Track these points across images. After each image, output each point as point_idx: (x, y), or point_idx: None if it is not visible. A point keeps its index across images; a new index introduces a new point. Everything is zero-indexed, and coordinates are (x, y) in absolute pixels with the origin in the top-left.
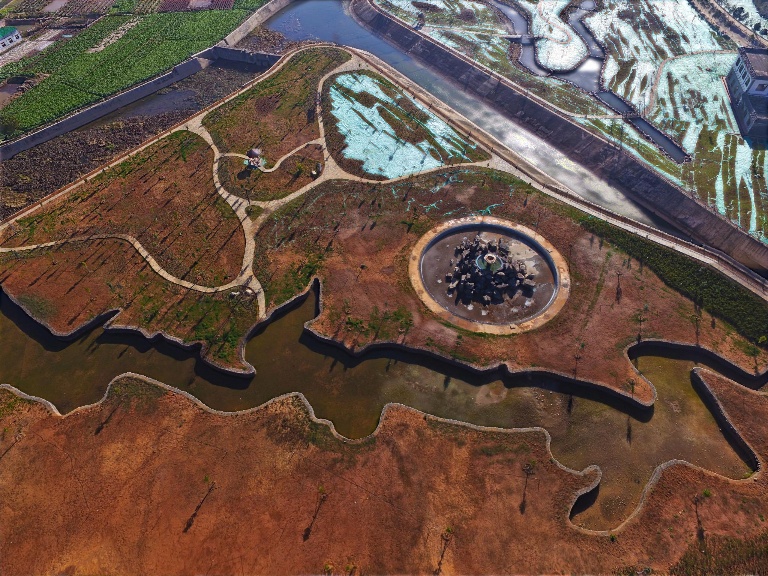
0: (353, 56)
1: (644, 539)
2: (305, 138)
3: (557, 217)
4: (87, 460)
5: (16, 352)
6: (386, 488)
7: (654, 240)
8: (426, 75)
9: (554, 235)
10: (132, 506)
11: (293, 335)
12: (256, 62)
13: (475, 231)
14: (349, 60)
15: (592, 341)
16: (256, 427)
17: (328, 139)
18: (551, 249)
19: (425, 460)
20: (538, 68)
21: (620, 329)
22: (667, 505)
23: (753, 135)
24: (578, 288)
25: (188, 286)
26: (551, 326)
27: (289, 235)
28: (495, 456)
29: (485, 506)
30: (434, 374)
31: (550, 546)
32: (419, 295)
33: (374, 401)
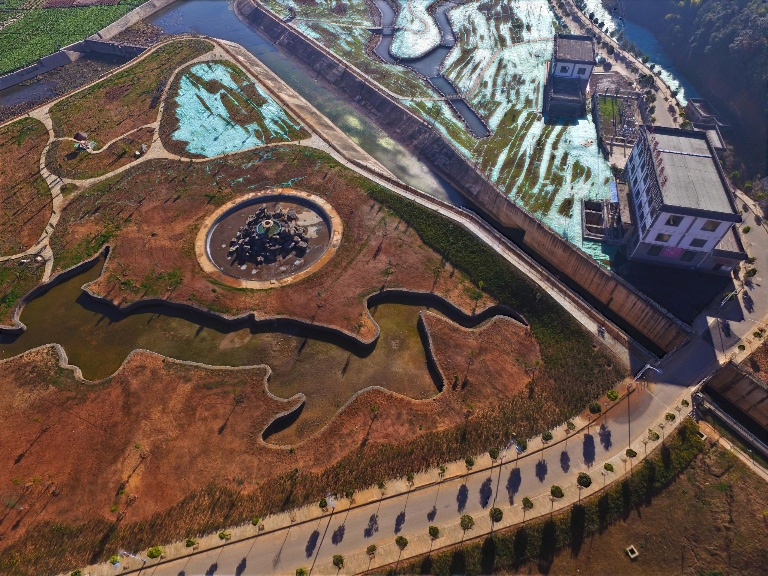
0: (216, 47)
1: (318, 450)
2: (141, 122)
3: (349, 187)
4: None
5: None
6: (106, 419)
7: (424, 204)
8: (286, 64)
9: (341, 203)
10: None
11: (72, 296)
12: (125, 54)
13: (273, 202)
14: (210, 51)
15: (338, 292)
16: (5, 374)
17: (162, 123)
18: (334, 215)
19: (150, 395)
20: (389, 56)
21: (368, 281)
22: (349, 422)
23: (552, 112)
24: (344, 248)
25: None
26: (308, 280)
27: (94, 209)
28: (214, 389)
29: (188, 429)
30: (190, 325)
31: (233, 458)
32: (198, 258)
33: (127, 349)
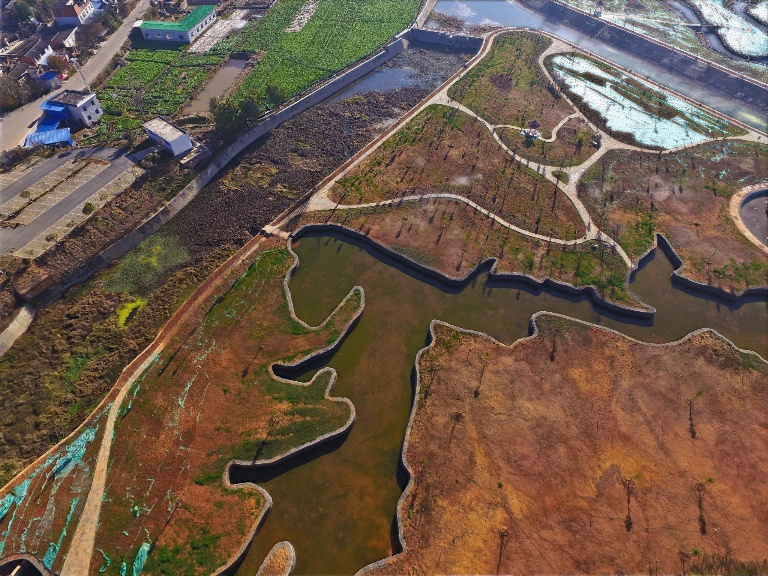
0: (553, 40)
1: None
2: (563, 112)
3: None
4: (562, 381)
5: (419, 294)
6: None
7: None
8: (624, 59)
9: None
10: (631, 418)
11: (664, 282)
12: (455, 44)
13: None
14: (552, 43)
15: None
16: (693, 356)
17: (585, 114)
18: None
19: None
20: (732, 54)
21: None
22: None
23: None
24: None
25: (546, 239)
26: None
27: (609, 197)
28: None
29: None
30: None
31: None
32: (762, 249)
33: None
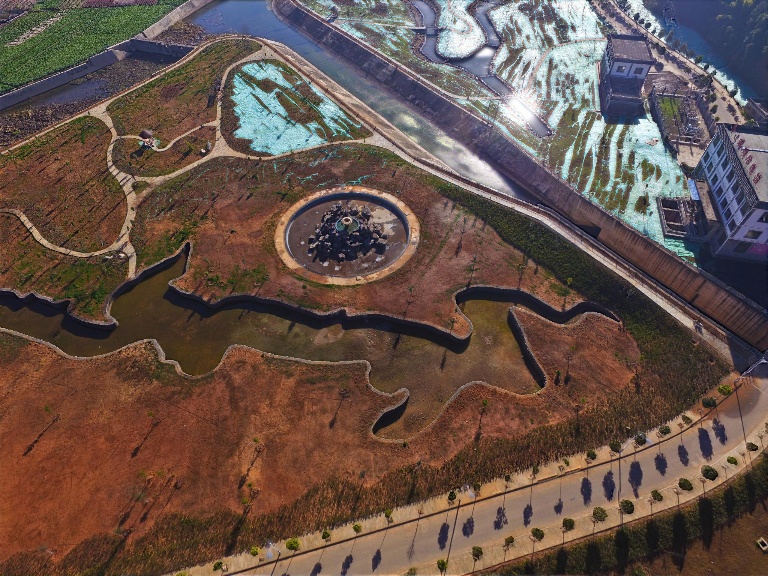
0: (263, 47)
1: (431, 443)
2: (201, 121)
3: (420, 185)
4: None
5: None
6: (215, 413)
7: (499, 202)
8: (333, 64)
9: (414, 201)
10: None
11: (159, 292)
12: (171, 54)
13: (345, 199)
14: (258, 50)
15: (426, 288)
16: (107, 368)
17: (223, 121)
18: (408, 213)
19: (255, 389)
20: (436, 56)
21: (453, 277)
22: (458, 416)
23: (611, 112)
24: (425, 245)
25: (65, 252)
26: (393, 277)
27: (169, 206)
28: (318, 384)
29: (299, 424)
30: (281, 321)
31: (348, 452)
32: (280, 254)
33: (222, 345)
